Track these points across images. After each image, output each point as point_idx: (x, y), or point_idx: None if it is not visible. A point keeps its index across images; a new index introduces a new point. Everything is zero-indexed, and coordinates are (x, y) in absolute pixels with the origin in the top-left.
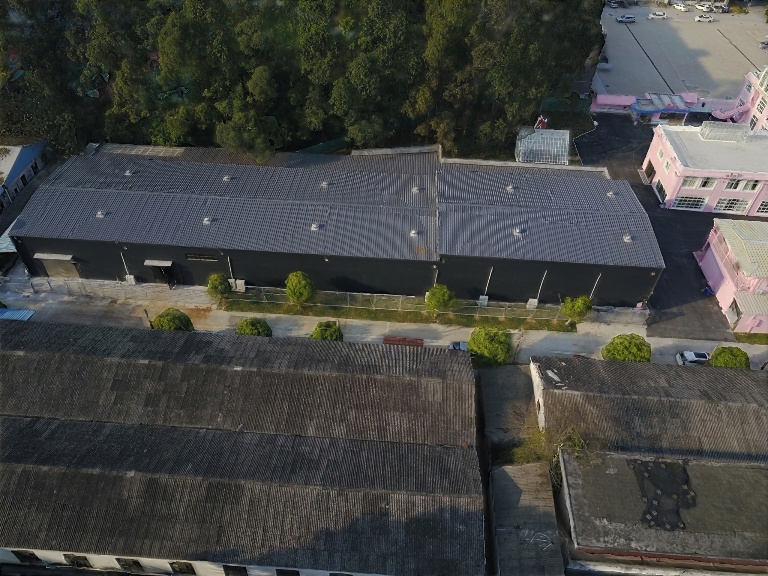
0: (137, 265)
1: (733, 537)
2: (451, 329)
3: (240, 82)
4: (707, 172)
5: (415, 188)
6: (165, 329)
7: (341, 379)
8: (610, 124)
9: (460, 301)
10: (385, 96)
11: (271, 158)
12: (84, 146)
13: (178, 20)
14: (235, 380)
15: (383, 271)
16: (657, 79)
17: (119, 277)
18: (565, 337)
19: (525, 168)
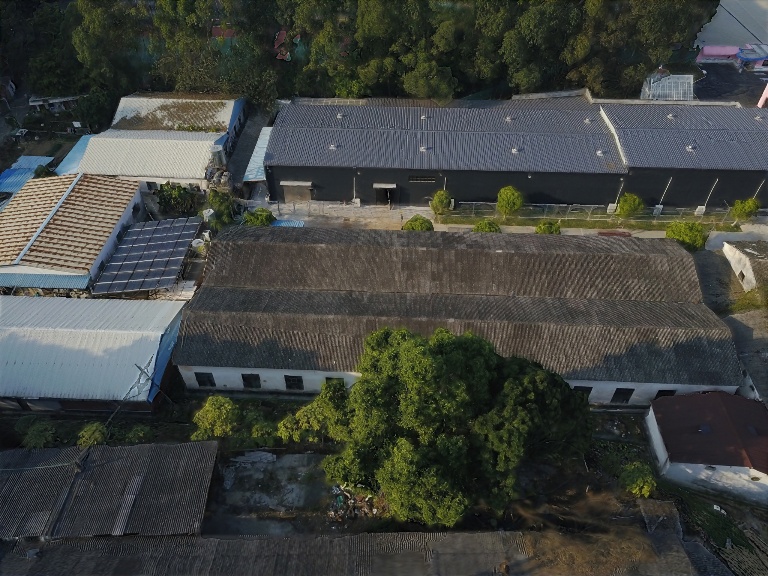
0: (364, 189)
1: None
2: (636, 232)
3: (423, 37)
4: None
5: (587, 120)
6: (419, 230)
7: (584, 257)
8: (717, 72)
9: (637, 211)
10: None
11: None
12: None
13: None
14: (499, 260)
15: (576, 185)
16: (746, 34)
17: (346, 201)
18: (734, 235)
19: (666, 105)
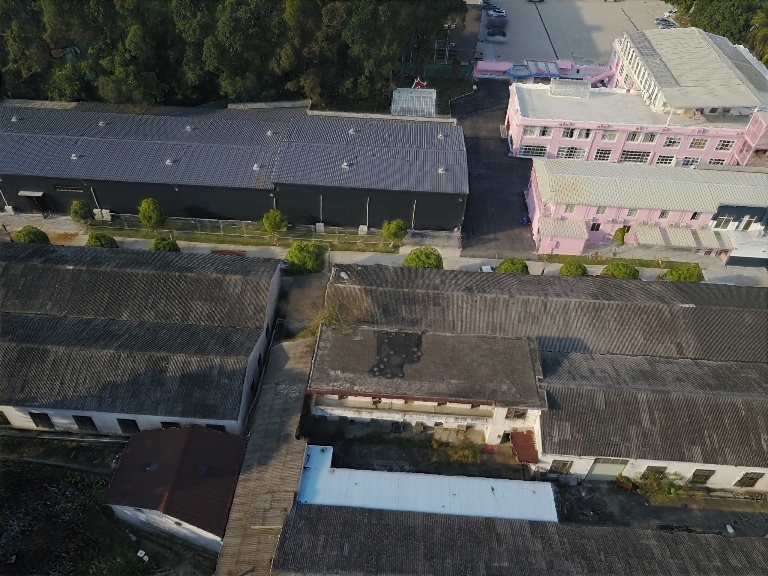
0: (14, 196)
1: (441, 383)
2: (287, 250)
3: (120, 40)
4: (543, 121)
5: (269, 132)
6: (20, 242)
7: (157, 276)
8: (488, 88)
9: (301, 228)
10: (257, 55)
11: (154, 111)
12: None
13: None
14: (66, 276)
15: (228, 200)
16: (548, 51)
17: None
18: (387, 257)
19: (384, 120)
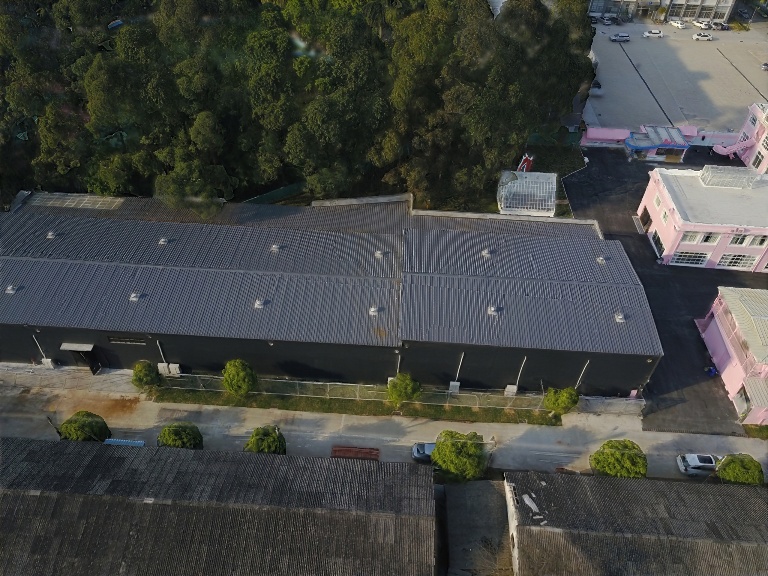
0: (54, 348)
1: None
2: (416, 423)
3: (182, 128)
4: (710, 227)
5: (378, 252)
6: (72, 440)
7: (273, 514)
8: (602, 160)
9: (428, 386)
10: (348, 141)
11: (220, 211)
12: (13, 195)
13: (105, 62)
14: (144, 517)
15: (337, 356)
16: (653, 106)
17: (35, 360)
18: (548, 432)
19: (506, 221)
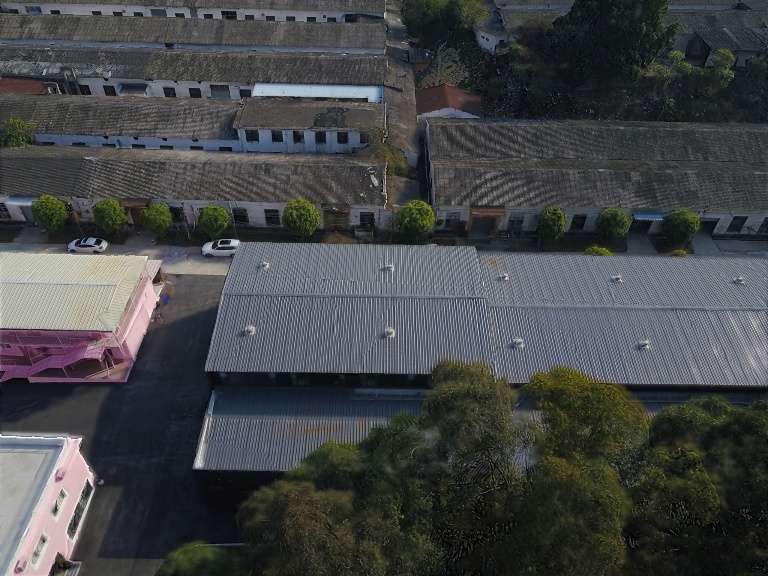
0: None
1: (305, 106)
2: None
3: None
4: None
5: (520, 340)
6: None
7: None
8: None
9: None
10: None
11: None
12: None
13: None
14: None
15: None
16: None
17: None
18: None
19: None
